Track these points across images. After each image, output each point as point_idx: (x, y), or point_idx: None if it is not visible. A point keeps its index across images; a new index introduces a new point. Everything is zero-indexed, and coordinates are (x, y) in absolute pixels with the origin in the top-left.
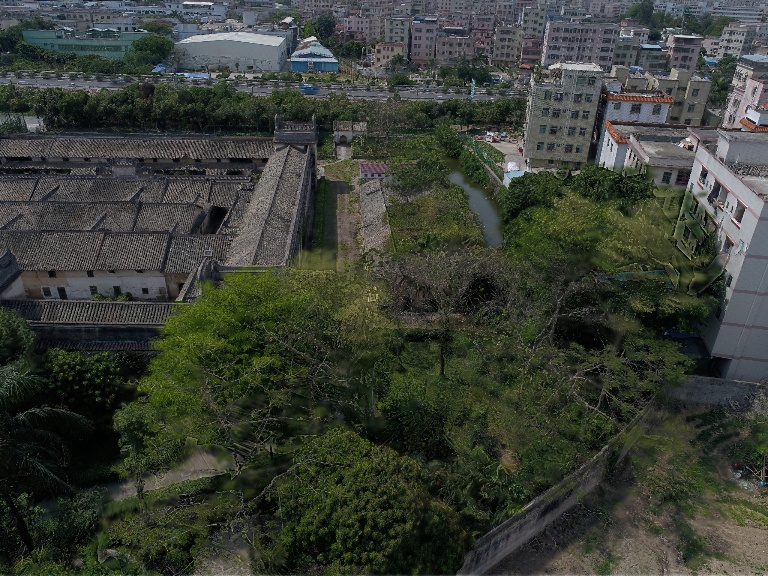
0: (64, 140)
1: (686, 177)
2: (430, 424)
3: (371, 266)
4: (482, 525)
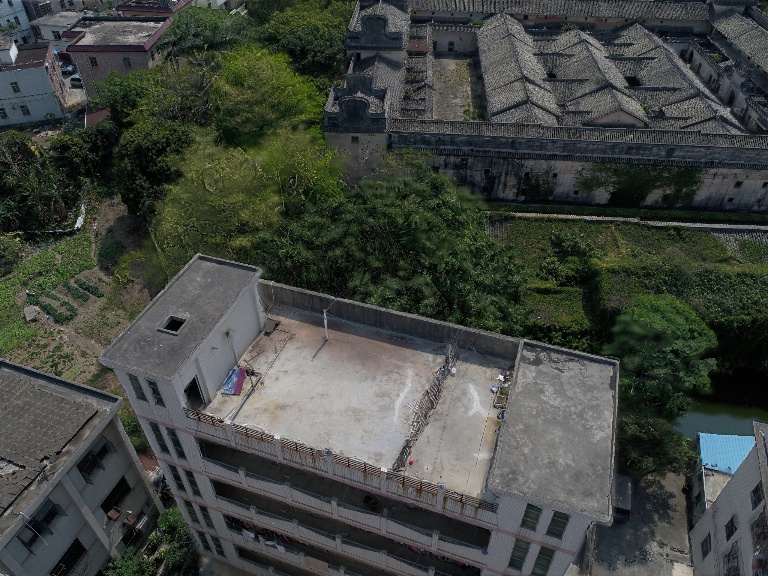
0: (760, 31)
1: (762, 530)
2: (251, 221)
3: (513, 212)
4: (144, 215)
